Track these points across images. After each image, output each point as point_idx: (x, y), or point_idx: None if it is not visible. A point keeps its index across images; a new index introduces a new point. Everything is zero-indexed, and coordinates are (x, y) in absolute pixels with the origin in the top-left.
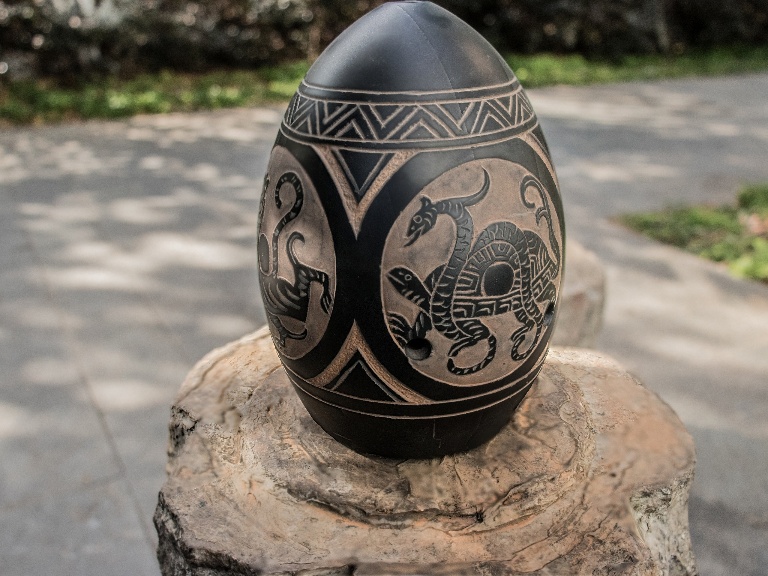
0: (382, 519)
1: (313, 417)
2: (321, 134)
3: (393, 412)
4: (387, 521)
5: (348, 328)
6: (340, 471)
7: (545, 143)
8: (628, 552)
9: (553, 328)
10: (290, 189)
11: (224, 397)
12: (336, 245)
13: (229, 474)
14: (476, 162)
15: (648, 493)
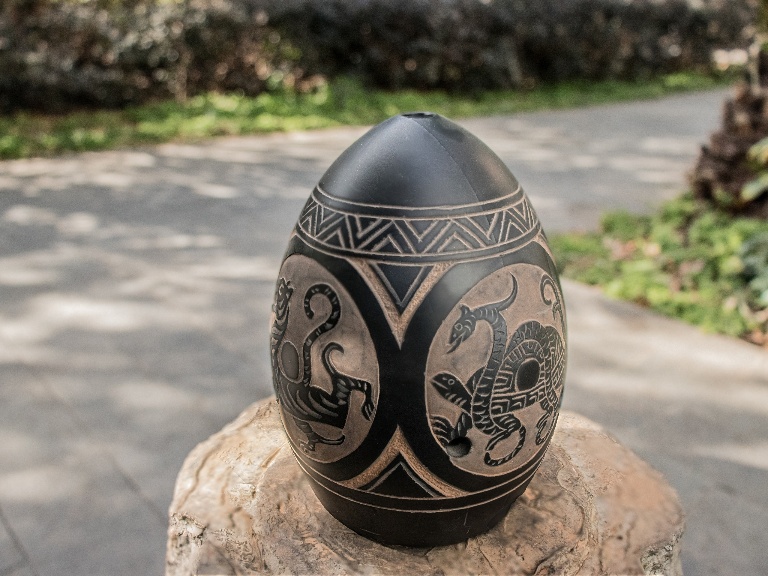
0: None
1: (333, 513)
2: (356, 248)
3: (430, 507)
4: None
5: (391, 433)
6: (372, 567)
7: None
8: None
9: None
10: (324, 301)
11: (226, 497)
12: (379, 355)
13: None
14: (505, 269)
15: (654, 552)
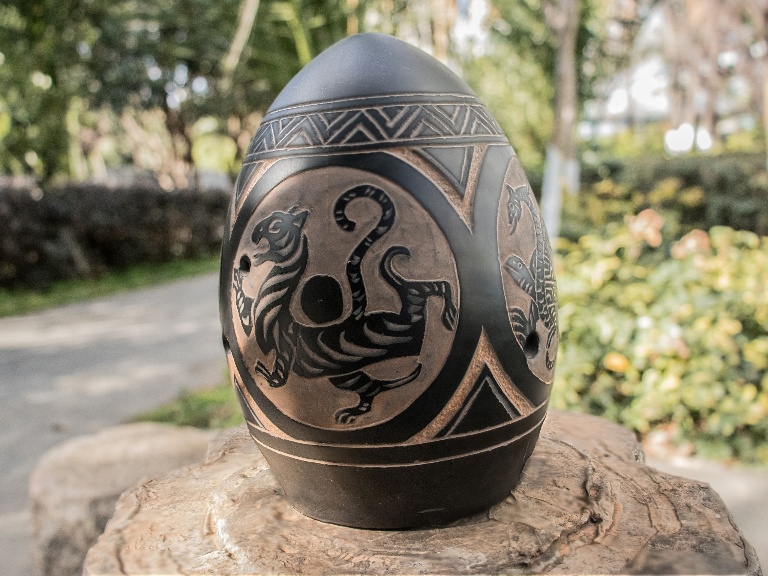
0: (541, 563)
1: (370, 516)
2: (391, 138)
3: (506, 436)
4: (545, 562)
5: (476, 339)
6: (453, 549)
7: None
8: (695, 486)
9: None
10: (367, 203)
11: None
12: (452, 246)
13: None
14: None
15: (637, 456)
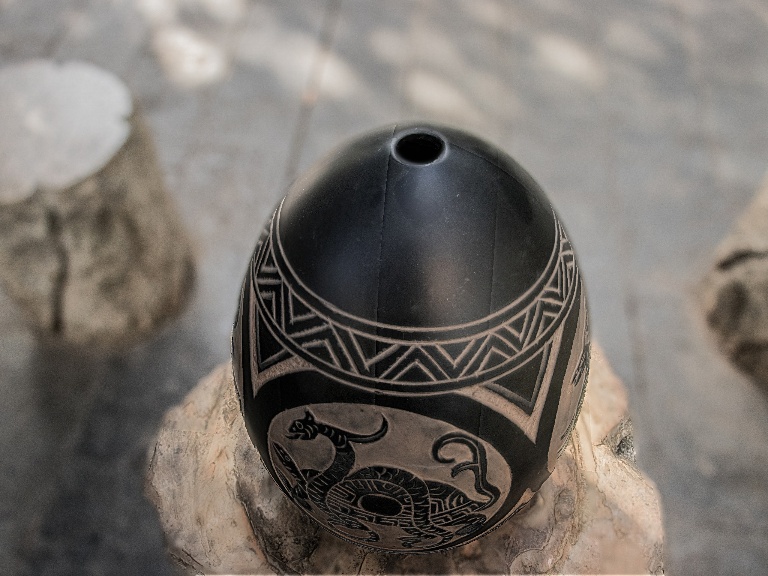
0: (276, 562)
1: None
2: (257, 278)
3: None
4: (279, 567)
5: None
6: (280, 493)
7: (533, 382)
8: None
9: (495, 524)
10: None
11: None
12: (244, 386)
13: (215, 432)
14: (376, 407)
15: None
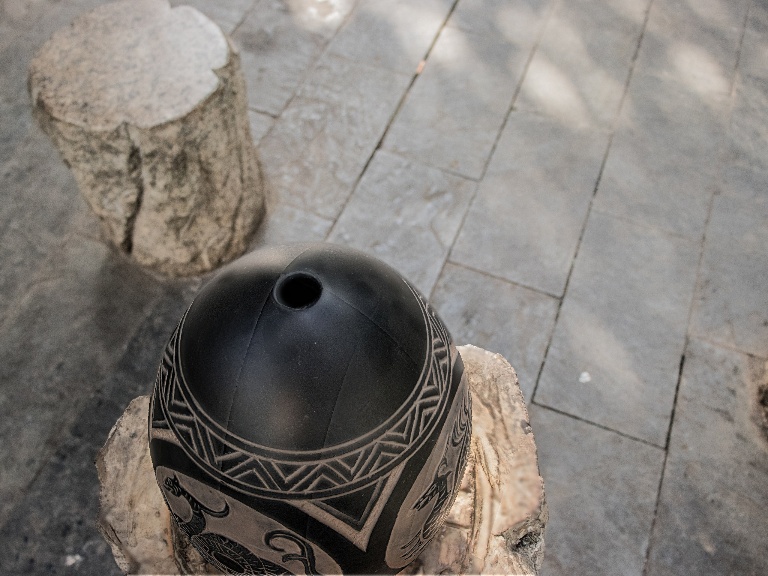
0: (180, 559)
1: None
2: None
3: None
4: (181, 563)
5: None
6: None
7: (363, 506)
8: None
9: None
10: None
11: None
12: None
13: None
14: (221, 493)
15: None
